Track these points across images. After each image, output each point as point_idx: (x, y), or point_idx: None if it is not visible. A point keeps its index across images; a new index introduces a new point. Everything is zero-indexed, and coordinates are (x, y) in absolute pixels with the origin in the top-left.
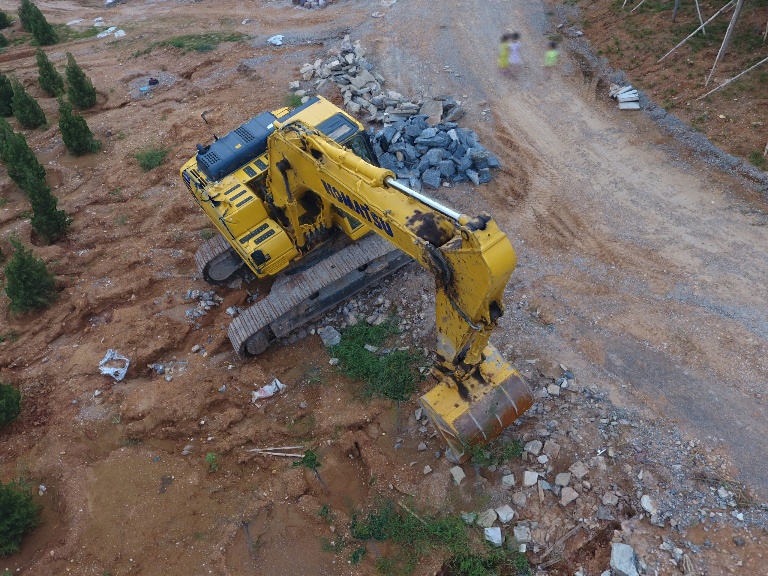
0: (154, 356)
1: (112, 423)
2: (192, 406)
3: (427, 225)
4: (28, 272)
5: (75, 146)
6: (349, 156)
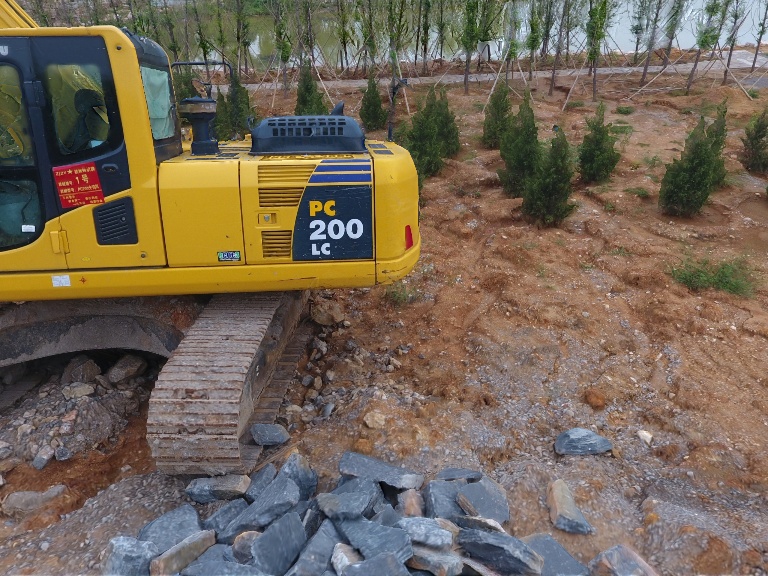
0: None
1: None
2: None
3: None
4: None
5: None
6: None
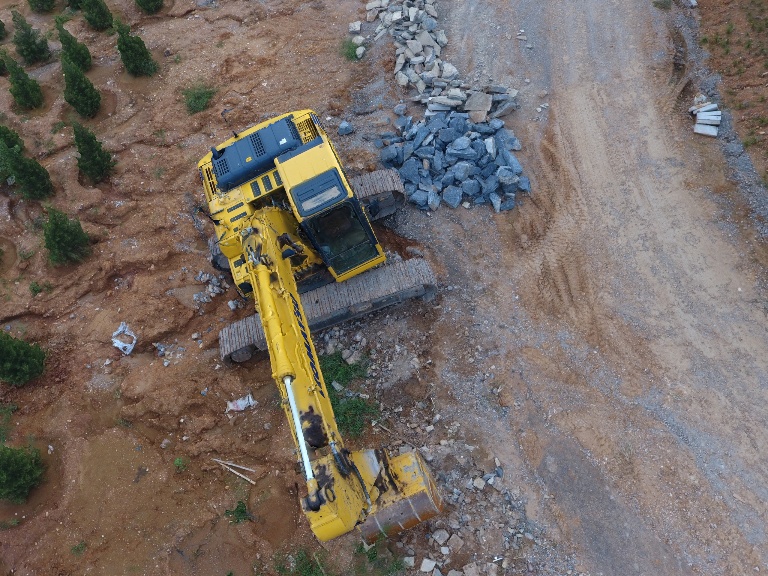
0: (159, 336)
1: (114, 397)
2: (176, 403)
3: (313, 429)
4: (61, 235)
5: (132, 68)
6: (271, 323)
